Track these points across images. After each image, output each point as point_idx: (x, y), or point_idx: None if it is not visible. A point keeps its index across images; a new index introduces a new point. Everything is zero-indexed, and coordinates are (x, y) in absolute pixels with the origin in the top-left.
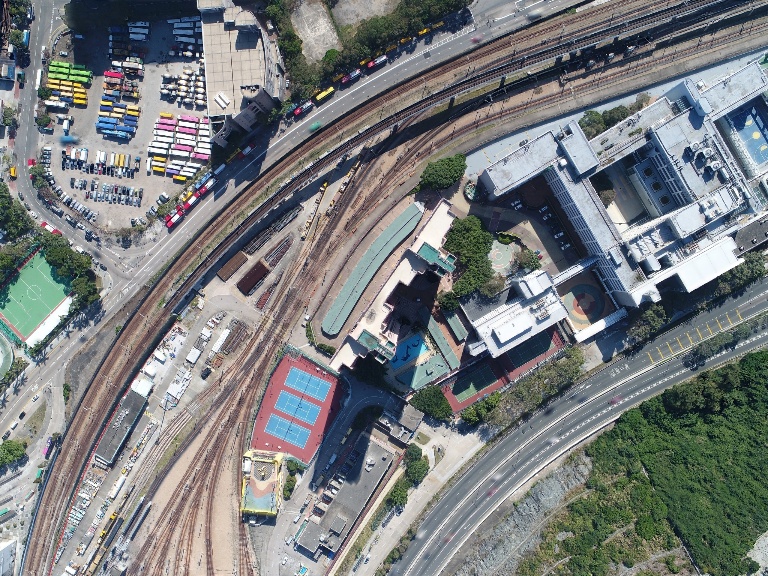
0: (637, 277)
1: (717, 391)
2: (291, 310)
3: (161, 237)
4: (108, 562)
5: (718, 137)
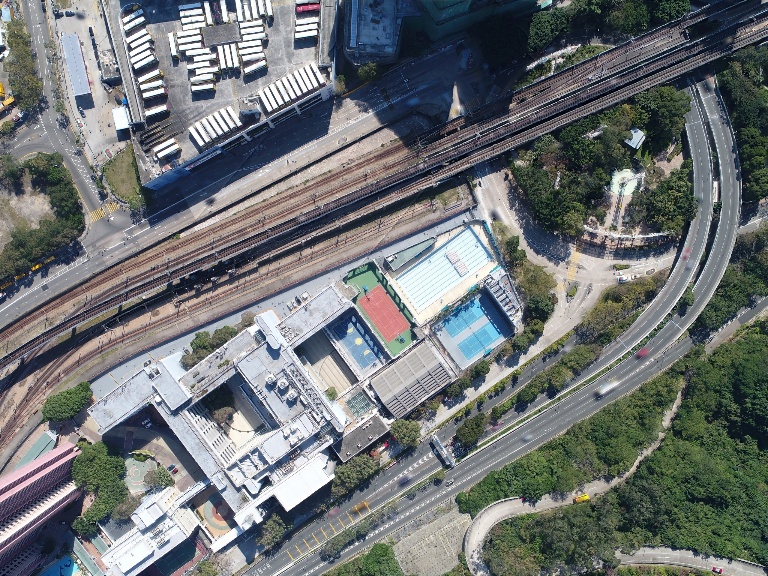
0: (242, 499)
1: None
2: None
3: None
4: None
5: (296, 365)
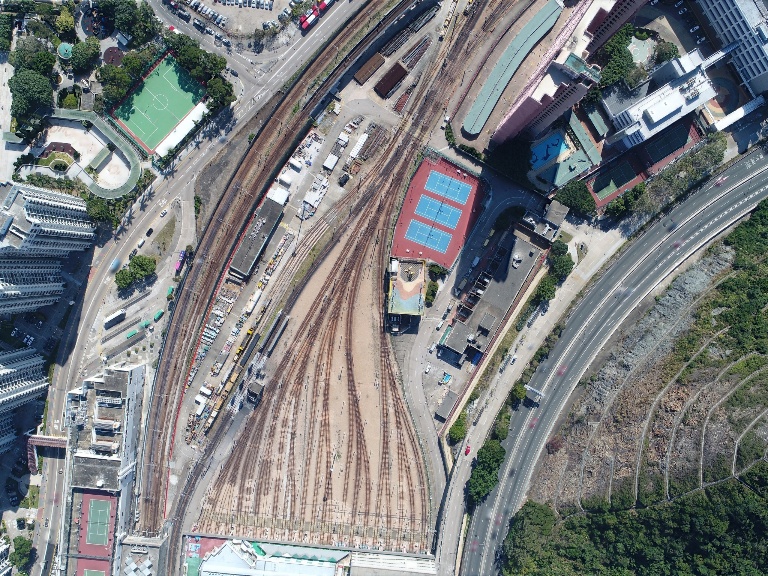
0: None
1: None
2: (430, 112)
3: (294, 41)
4: (244, 381)
5: None
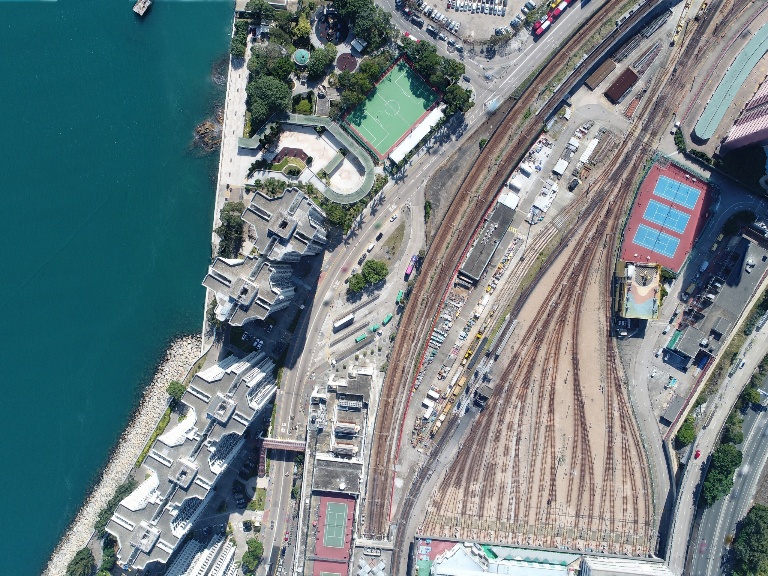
0: None
1: None
2: (659, 118)
3: (526, 46)
4: None
5: None
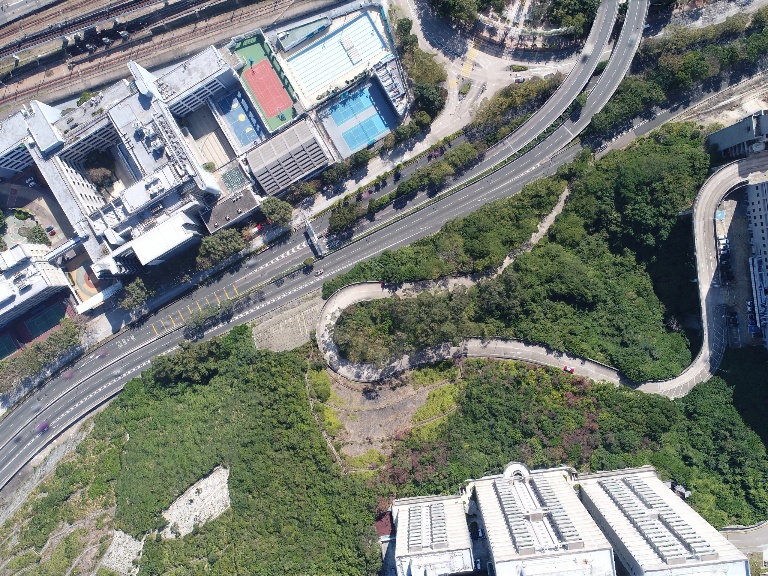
0: (103, 250)
1: (193, 361)
2: None
3: None
4: None
5: (165, 117)
